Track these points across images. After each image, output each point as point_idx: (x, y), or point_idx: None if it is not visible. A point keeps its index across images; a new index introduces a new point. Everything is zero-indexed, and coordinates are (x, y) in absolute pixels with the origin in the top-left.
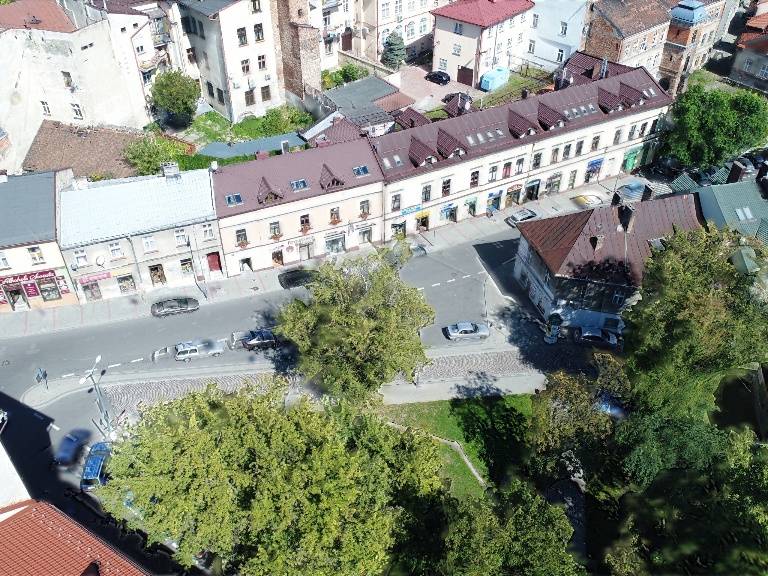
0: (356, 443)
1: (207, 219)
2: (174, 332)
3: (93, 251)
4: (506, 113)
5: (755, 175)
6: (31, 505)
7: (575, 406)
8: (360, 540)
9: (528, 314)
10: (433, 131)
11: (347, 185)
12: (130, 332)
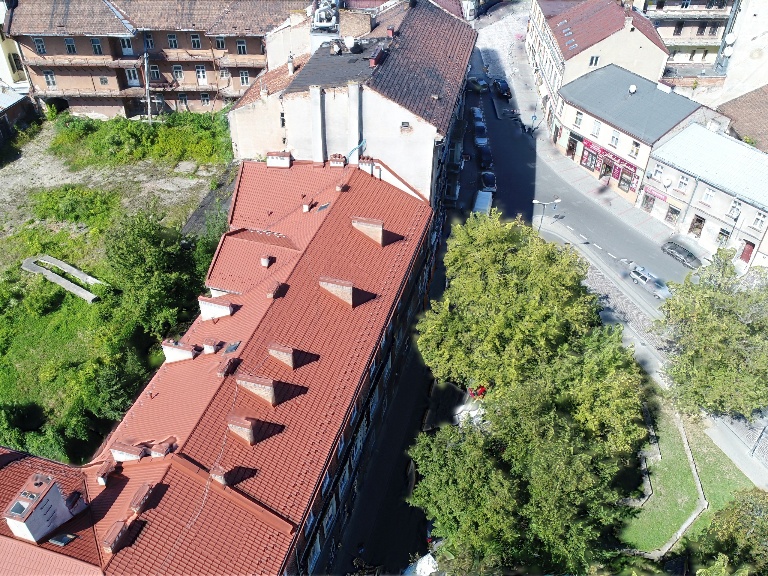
0: (586, 352)
1: (764, 208)
2: (657, 264)
3: (668, 172)
4: None
5: None
6: (426, 203)
7: (760, 517)
8: (500, 371)
9: None
10: None
11: None
12: (634, 241)
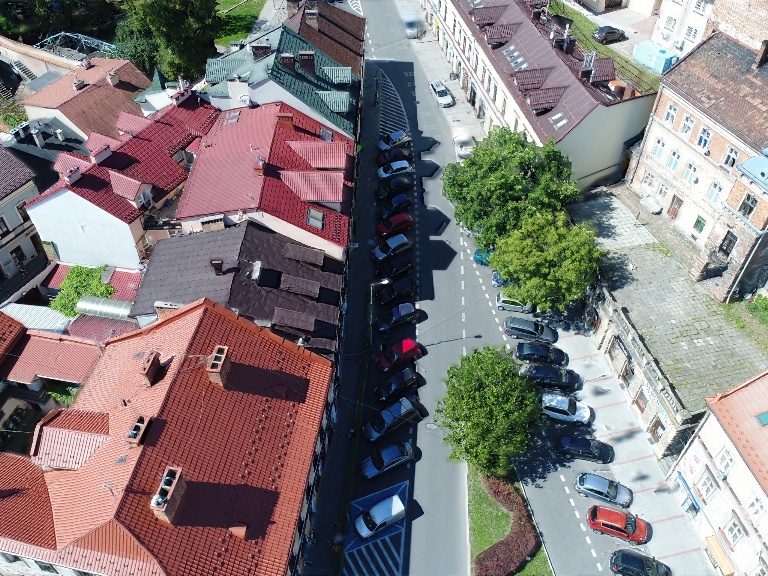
0: None
1: None
2: None
3: None
4: (504, 4)
5: (503, 337)
6: None
7: None
8: None
9: None
10: None
11: None
12: None
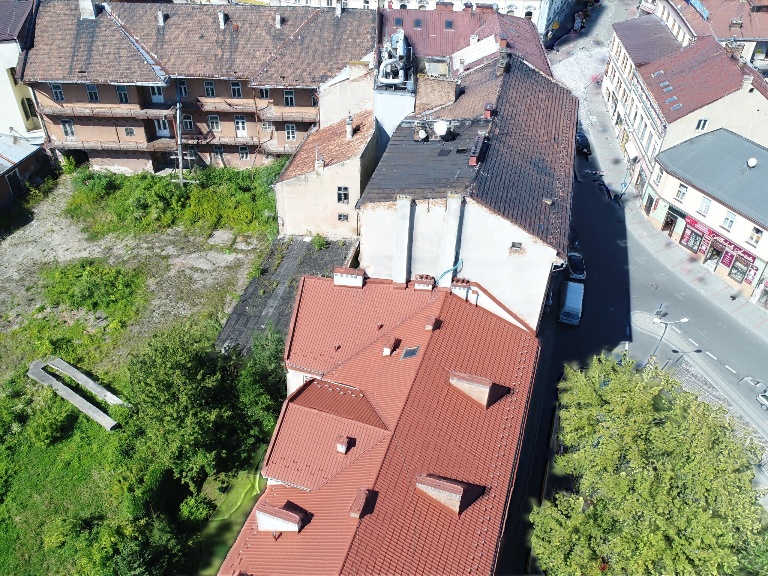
0: (761, 570)
1: None
2: None
3: None
4: None
5: None
6: (531, 333)
7: None
8: None
9: None
10: None
11: None
12: (754, 349)
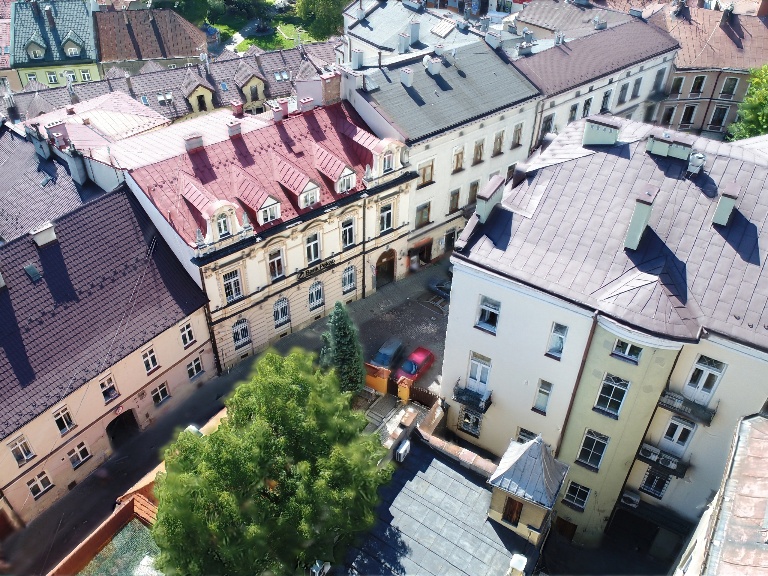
0: None
1: None
2: None
3: None
4: None
5: None
6: None
7: None
8: None
9: None
10: None
11: None
12: None
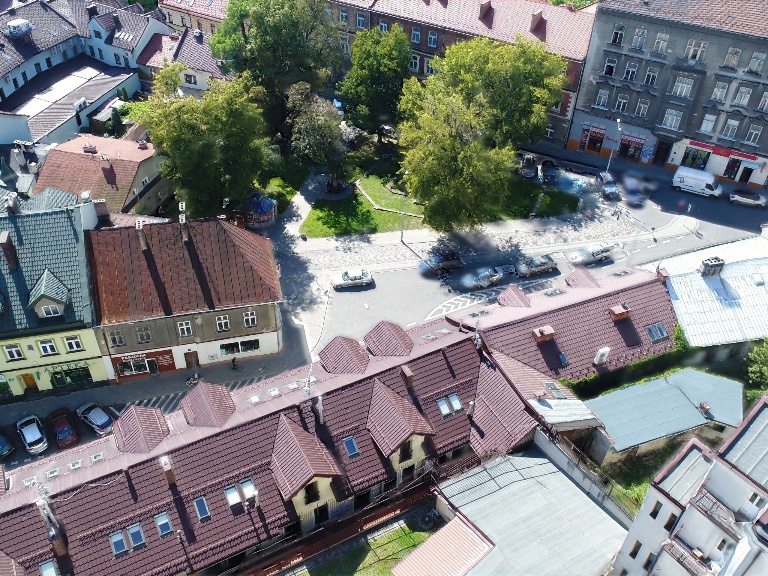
0: None
1: None
2: None
3: None
4: (232, 421)
5: None
6: None
7: None
8: None
9: (286, 303)
10: (375, 369)
11: (494, 305)
12: None
